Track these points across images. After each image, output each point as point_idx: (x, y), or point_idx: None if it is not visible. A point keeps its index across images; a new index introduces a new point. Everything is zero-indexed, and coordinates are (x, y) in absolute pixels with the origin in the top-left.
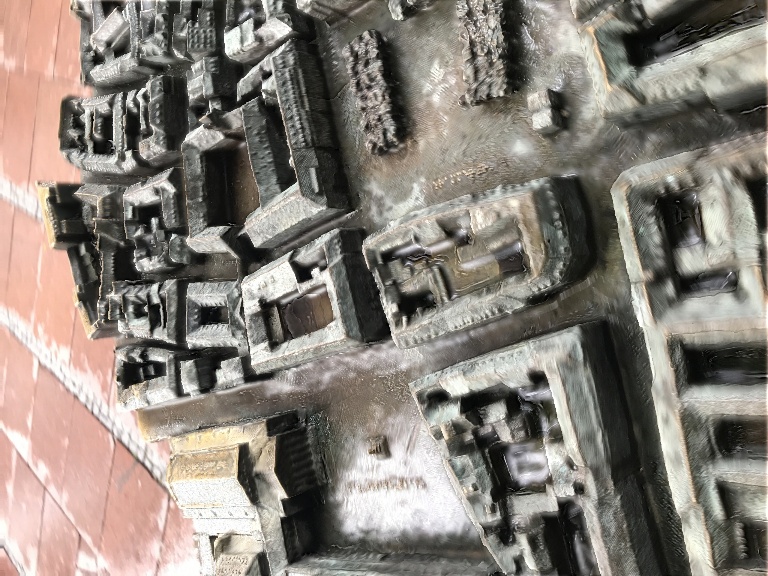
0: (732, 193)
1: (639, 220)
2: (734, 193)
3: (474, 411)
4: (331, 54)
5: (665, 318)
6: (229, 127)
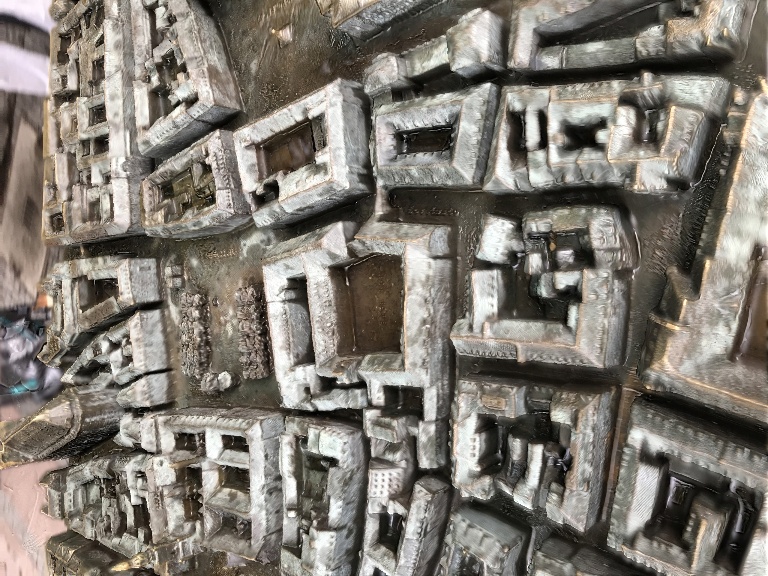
0: None
1: None
2: None
3: None
4: None
5: None
6: None
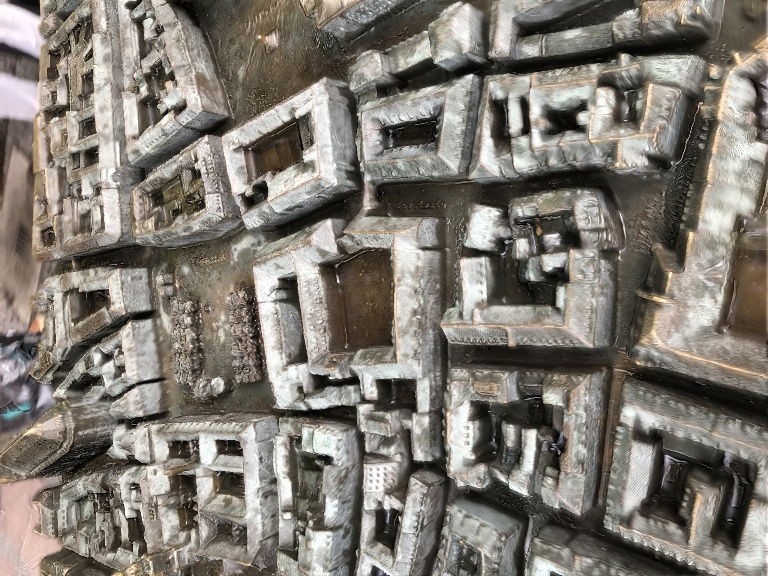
0: None
1: None
2: (92, 226)
3: None
4: None
5: None
6: None
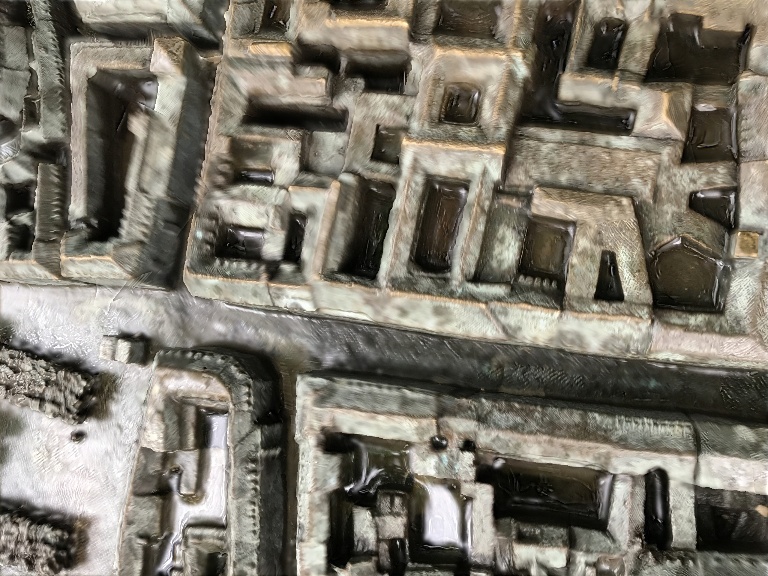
0: (233, 196)
1: (220, 272)
2: (234, 194)
3: (355, 556)
4: None
5: (307, 277)
6: None
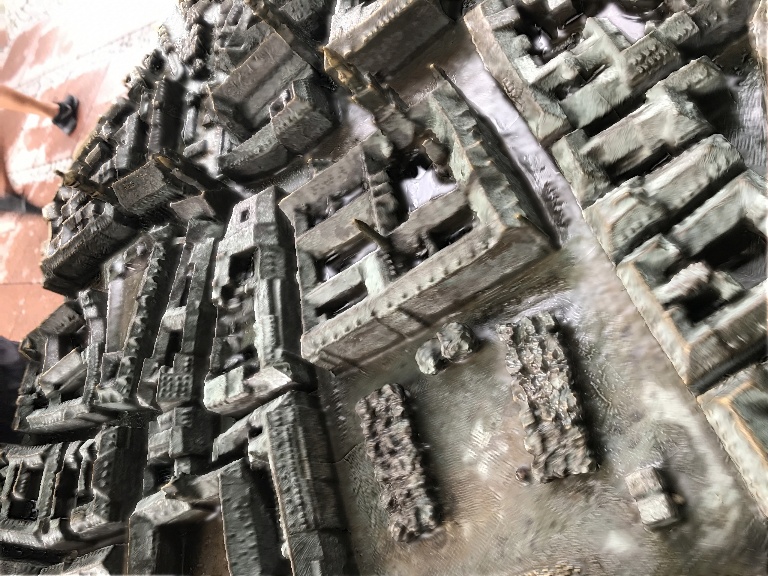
0: None
1: None
2: None
3: None
4: (337, 408)
5: None
6: (199, 496)
